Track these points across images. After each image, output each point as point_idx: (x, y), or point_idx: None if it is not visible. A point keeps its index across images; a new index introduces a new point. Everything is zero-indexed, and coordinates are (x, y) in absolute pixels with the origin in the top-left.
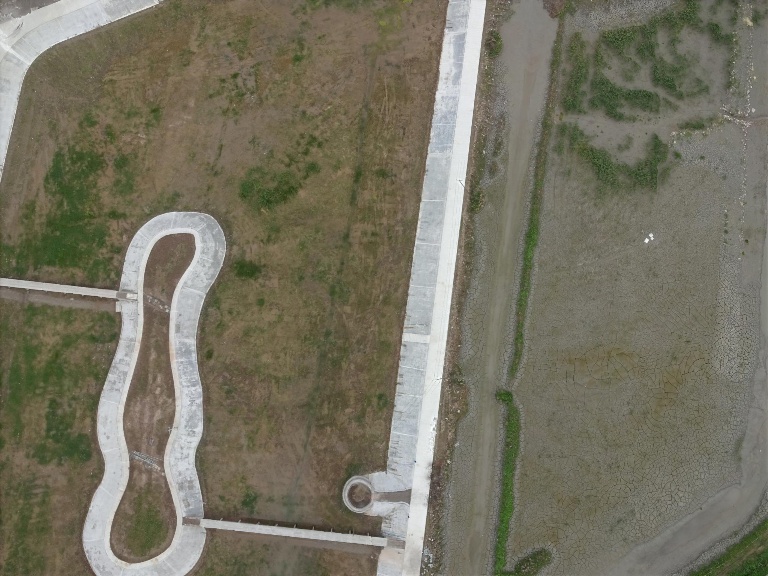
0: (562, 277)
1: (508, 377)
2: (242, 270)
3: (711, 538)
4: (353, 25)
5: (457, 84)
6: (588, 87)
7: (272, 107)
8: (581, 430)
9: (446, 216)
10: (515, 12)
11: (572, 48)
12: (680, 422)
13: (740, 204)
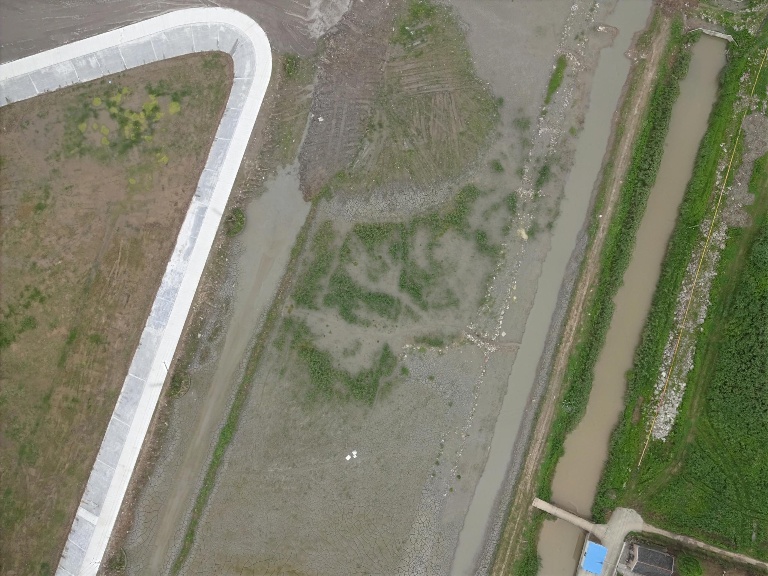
0: (250, 480)
1: (170, 573)
2: None
3: None
4: (102, 179)
5: (186, 260)
6: (327, 281)
7: (5, 254)
8: None
9: (142, 397)
10: (268, 189)
11: (317, 238)
12: None
13: (461, 435)
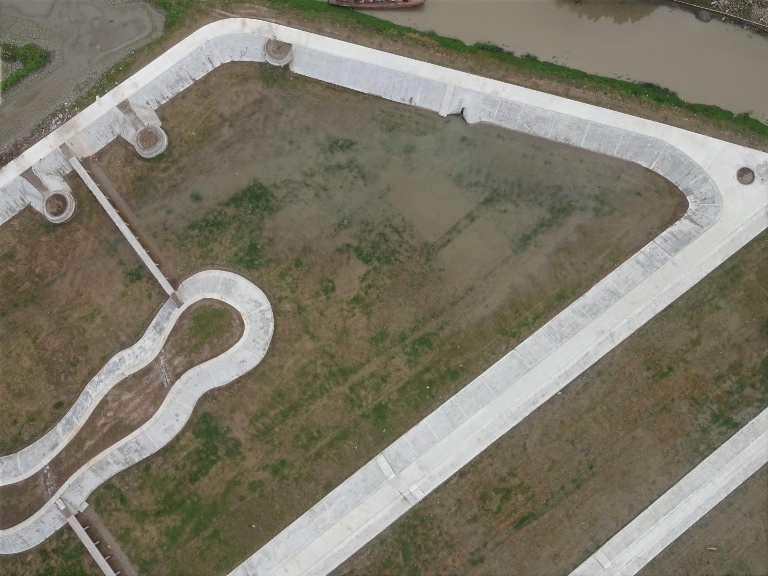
0: None
1: None
2: None
3: None
4: None
5: None
6: None
7: None
8: None
9: None
10: None
11: None
12: None
13: None
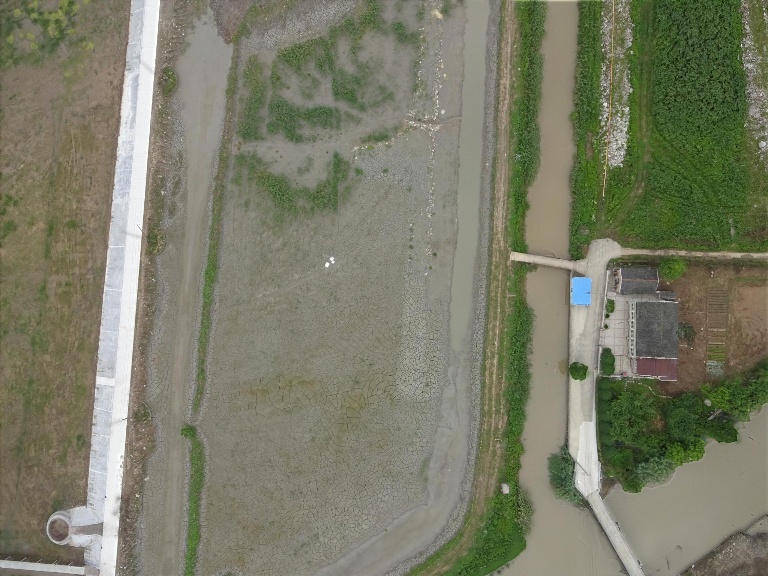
0: (242, 310)
1: (192, 412)
2: None
3: (396, 559)
4: (40, 81)
5: (133, 128)
6: (266, 111)
7: None
8: (264, 459)
9: (126, 261)
10: (190, 44)
11: (246, 73)
12: (363, 446)
13: (427, 216)
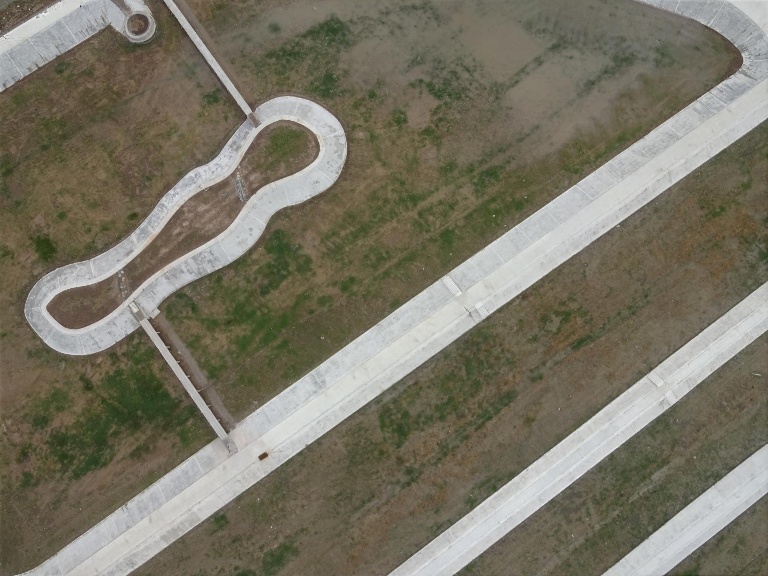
0: None
1: None
2: (48, 251)
3: None
4: None
5: None
6: None
7: None
8: None
9: None
10: None
11: None
12: None
13: None
